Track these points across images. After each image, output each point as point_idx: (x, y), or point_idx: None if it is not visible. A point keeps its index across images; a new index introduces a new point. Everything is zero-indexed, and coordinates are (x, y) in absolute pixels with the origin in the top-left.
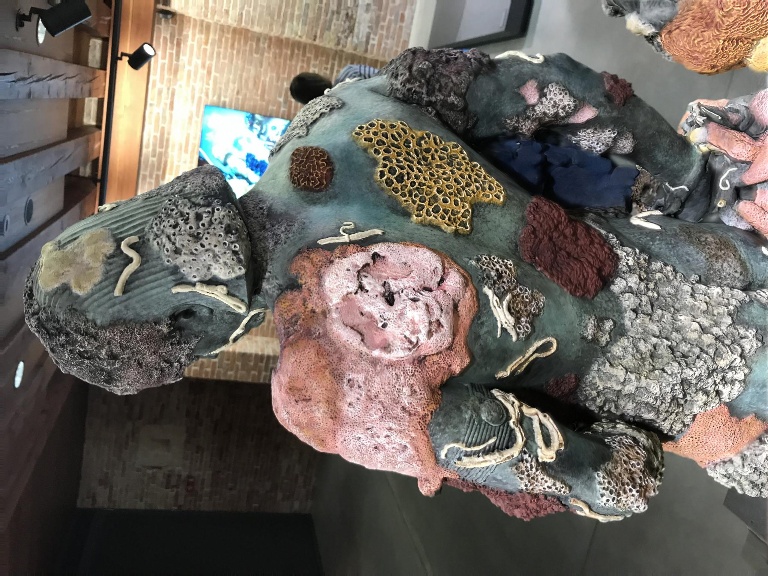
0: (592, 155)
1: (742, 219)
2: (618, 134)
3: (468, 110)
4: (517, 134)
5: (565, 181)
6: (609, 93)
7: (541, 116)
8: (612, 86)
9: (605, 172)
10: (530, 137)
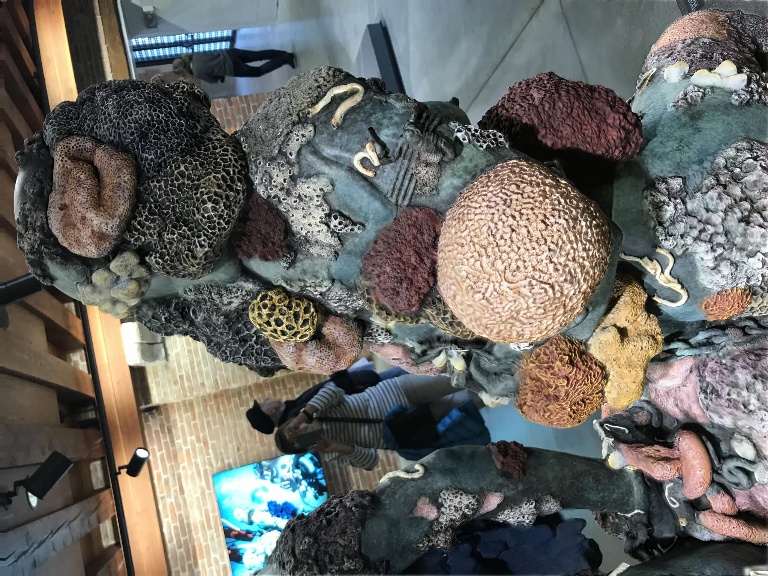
0: (525, 529)
1: (713, 531)
2: (536, 502)
3: (371, 562)
4: (437, 549)
5: (516, 560)
6: (503, 471)
7: (450, 523)
8: (503, 463)
9: (549, 538)
10: (452, 547)
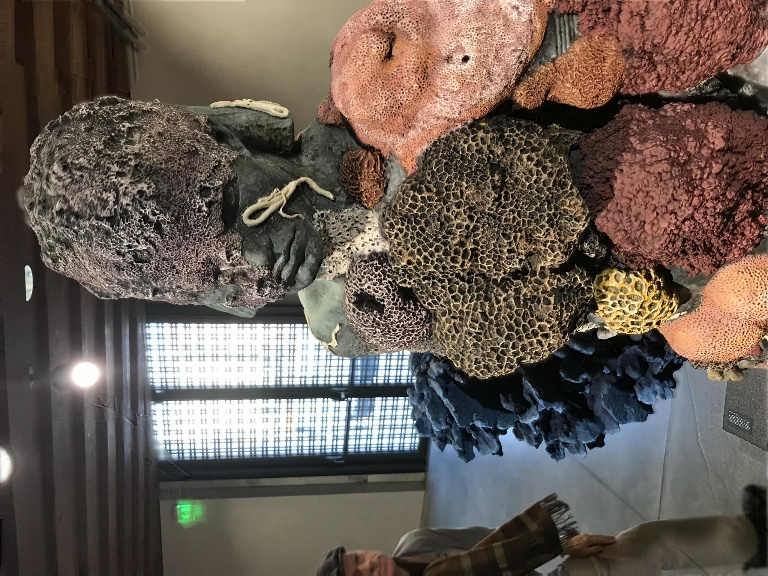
0: None
1: None
2: None
3: None
4: None
5: None
6: None
7: None
8: None
9: None
10: None
